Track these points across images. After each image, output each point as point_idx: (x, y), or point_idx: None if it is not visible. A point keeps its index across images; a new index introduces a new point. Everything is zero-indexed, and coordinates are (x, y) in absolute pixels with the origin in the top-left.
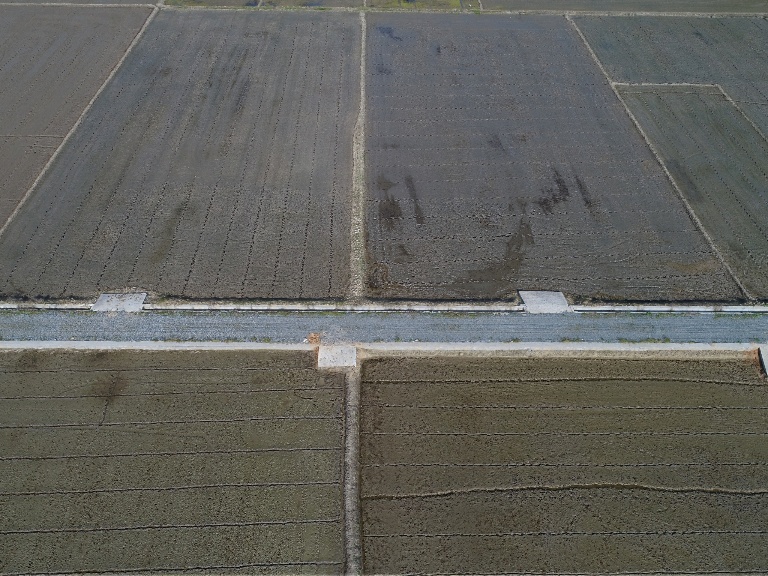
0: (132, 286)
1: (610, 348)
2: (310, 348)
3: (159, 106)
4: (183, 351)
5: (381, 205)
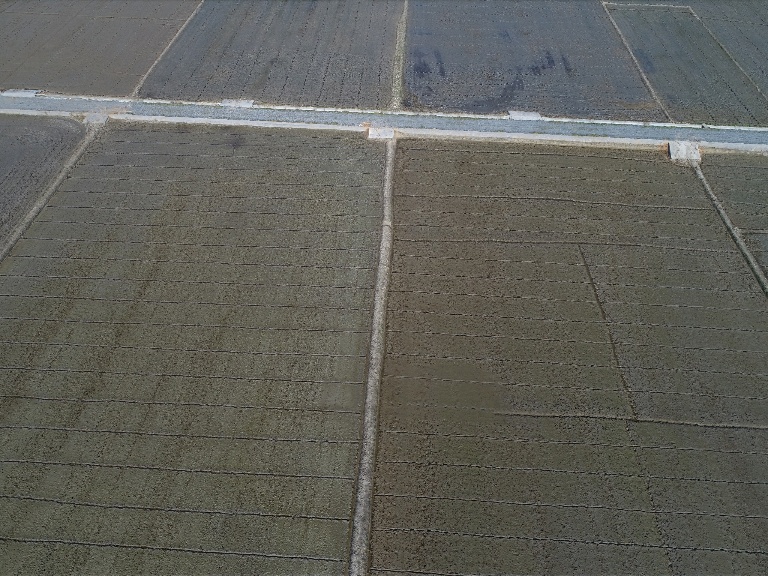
0: (243, 98)
1: (565, 139)
2: (363, 130)
3: (253, 5)
4: (280, 128)
5: (415, 65)
